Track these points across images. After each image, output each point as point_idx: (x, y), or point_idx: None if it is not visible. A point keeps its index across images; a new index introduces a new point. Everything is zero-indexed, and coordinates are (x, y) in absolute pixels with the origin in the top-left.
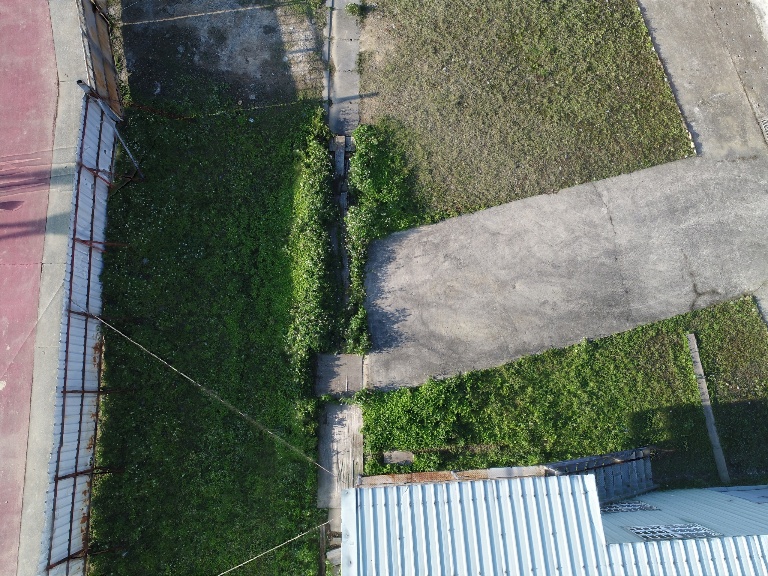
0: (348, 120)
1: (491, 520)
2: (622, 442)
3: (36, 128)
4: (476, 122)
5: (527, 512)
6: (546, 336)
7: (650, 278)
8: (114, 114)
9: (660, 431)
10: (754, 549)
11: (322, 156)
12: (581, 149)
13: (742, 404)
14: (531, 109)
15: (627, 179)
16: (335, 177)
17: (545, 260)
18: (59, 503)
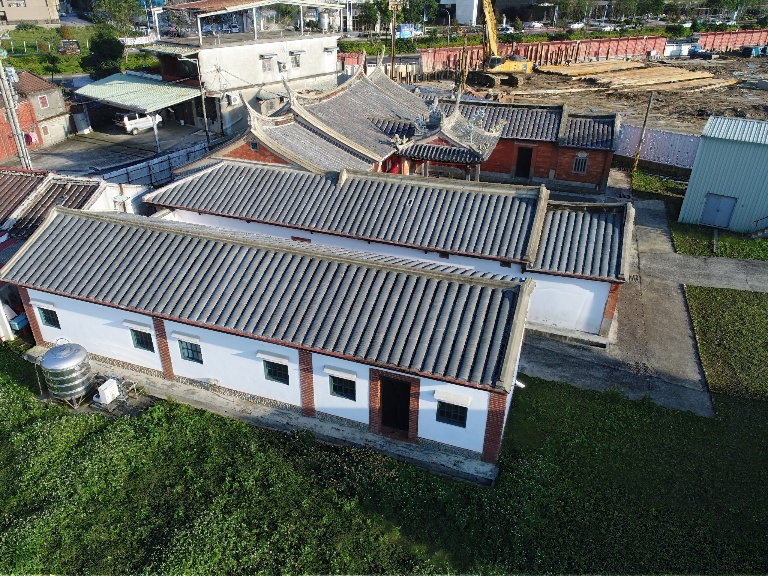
0: None
1: None
2: (762, 243)
3: None
4: None
5: None
6: None
7: None
8: None
9: None
10: None
11: None
12: None
13: None
14: None
15: None
16: None
17: None
18: None
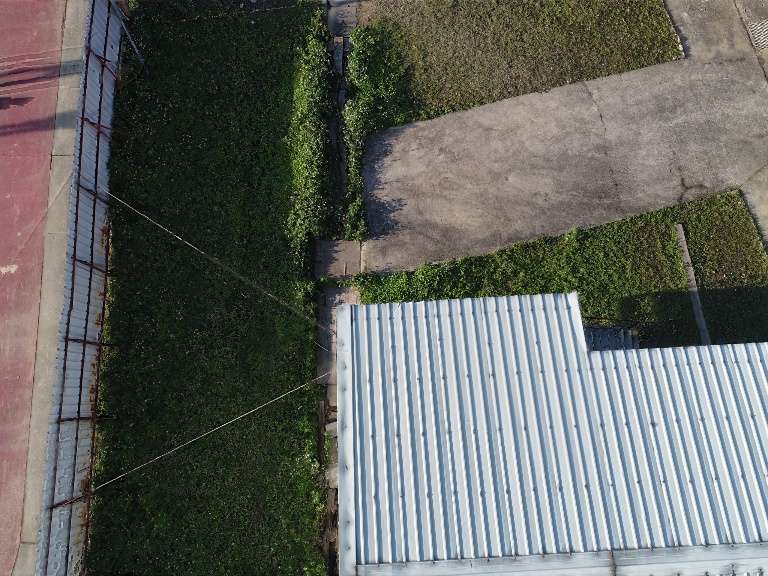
0: (346, 22)
1: (479, 331)
2: (611, 324)
3: (45, 29)
4: (470, 24)
5: (513, 325)
6: (538, 225)
7: (639, 172)
8: (121, 11)
9: (648, 315)
10: (728, 356)
11: (321, 53)
12: (572, 50)
13: (728, 291)
14: (523, 12)
15: (617, 79)
16: (334, 75)
17: (537, 154)
18: (69, 364)
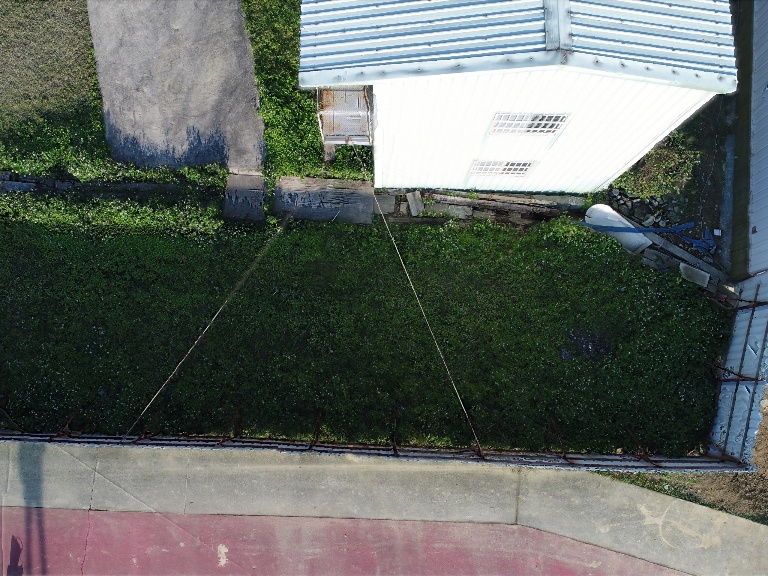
0: None
1: None
2: None
3: None
4: None
5: None
6: (228, 7)
7: None
8: None
9: None
10: None
11: (7, 198)
12: None
13: None
14: None
15: None
16: None
17: (154, 0)
18: None
